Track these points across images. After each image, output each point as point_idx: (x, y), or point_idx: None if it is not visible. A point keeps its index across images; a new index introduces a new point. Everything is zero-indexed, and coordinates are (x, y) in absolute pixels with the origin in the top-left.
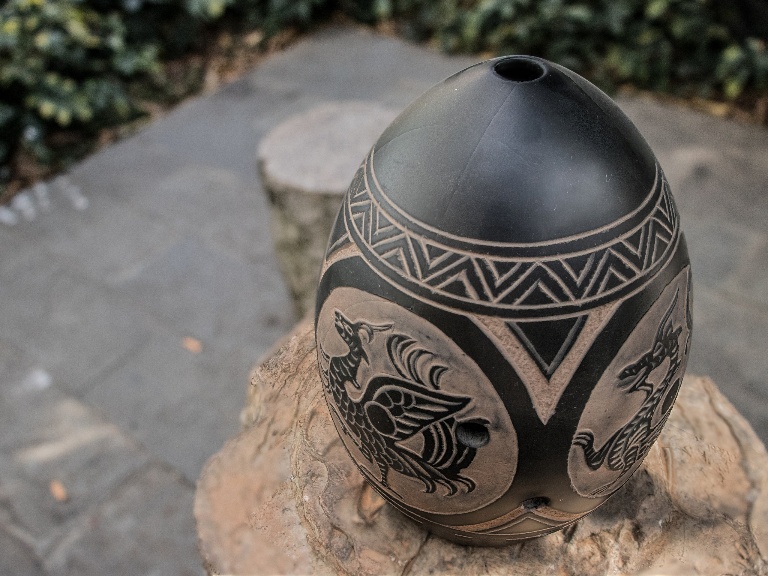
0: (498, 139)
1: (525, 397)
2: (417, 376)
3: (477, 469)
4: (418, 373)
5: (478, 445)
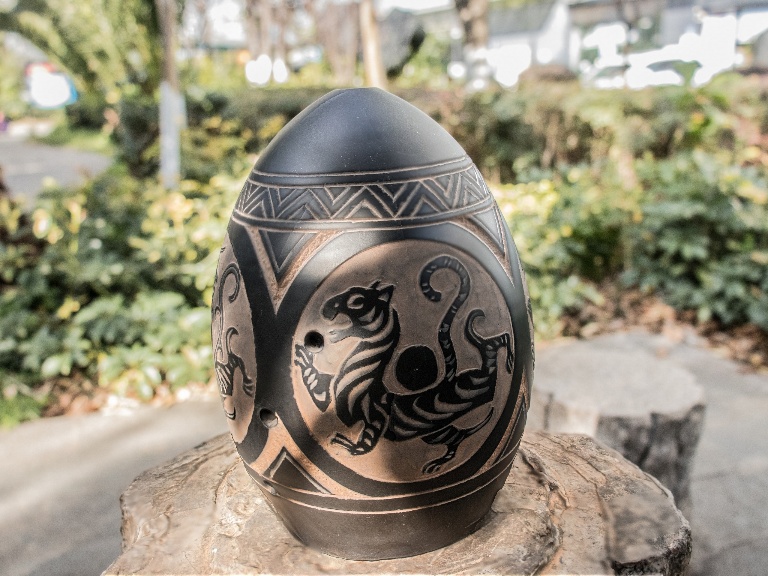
0: None
1: None
2: None
3: None
4: None
5: None
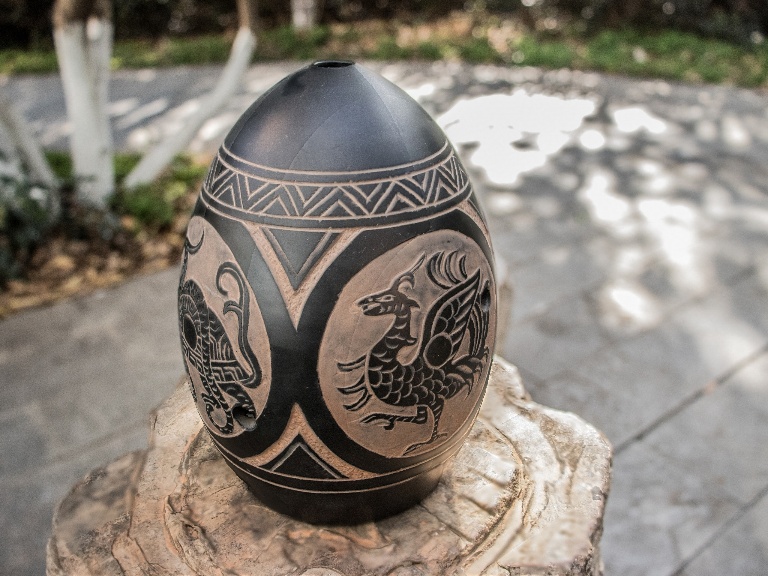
0: (387, 94)
1: (489, 249)
2: (455, 279)
3: (489, 332)
4: (454, 276)
5: (488, 307)
